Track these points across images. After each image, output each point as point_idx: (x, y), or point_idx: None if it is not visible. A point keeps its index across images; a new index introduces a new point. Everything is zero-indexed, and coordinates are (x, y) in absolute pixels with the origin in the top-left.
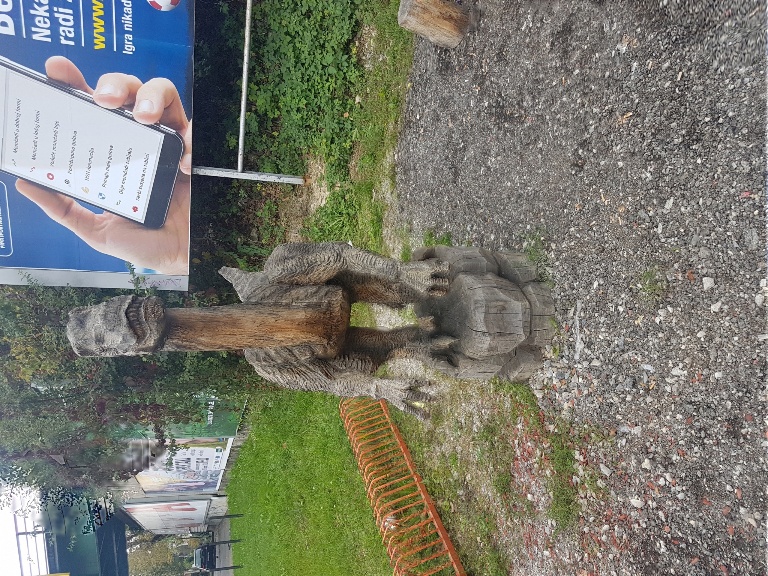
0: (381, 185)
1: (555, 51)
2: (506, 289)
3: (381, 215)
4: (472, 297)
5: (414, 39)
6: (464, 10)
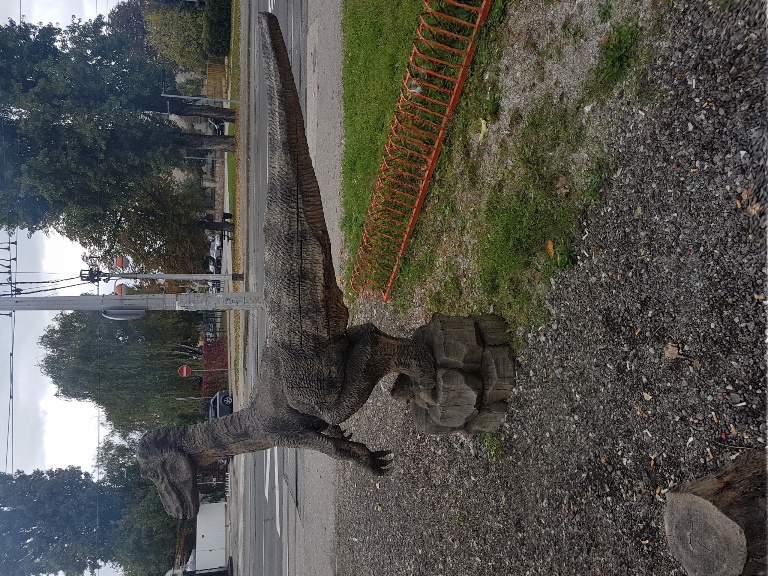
0: None
1: None
2: None
3: None
4: None
5: None
6: None
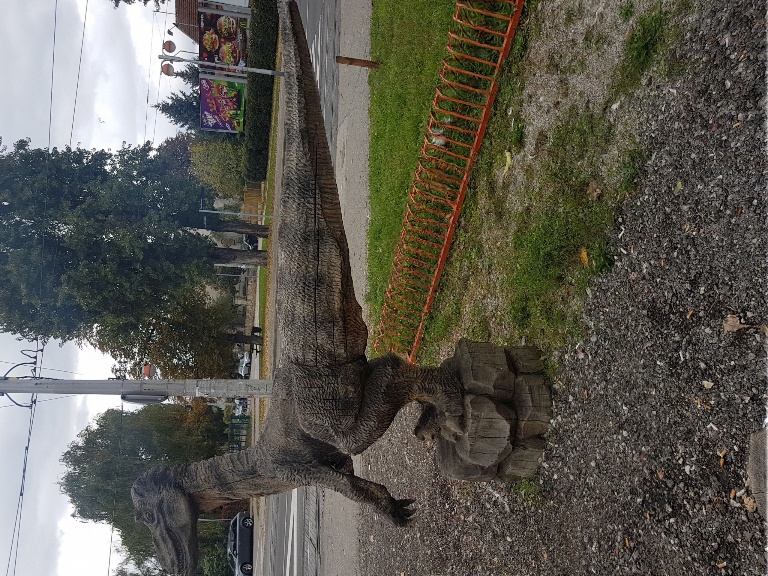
0: None
1: None
2: None
3: None
4: None
5: None
6: None
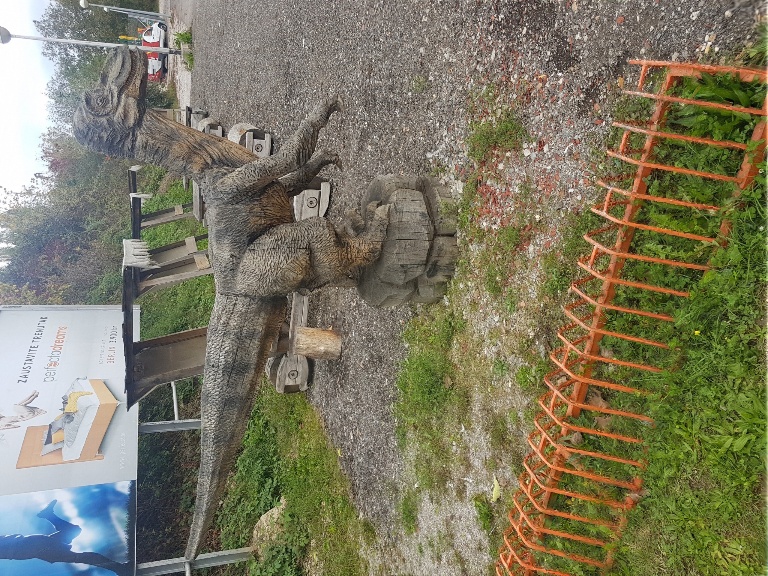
0: None
1: None
2: None
3: None
4: None
5: None
6: None
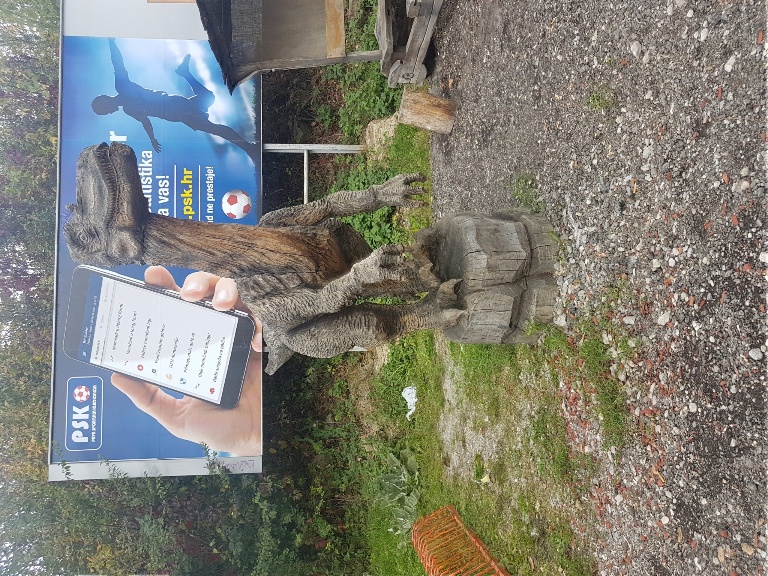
0: None
1: (504, 46)
2: (498, 219)
3: (432, 333)
4: (462, 226)
5: (431, 167)
6: (451, 99)
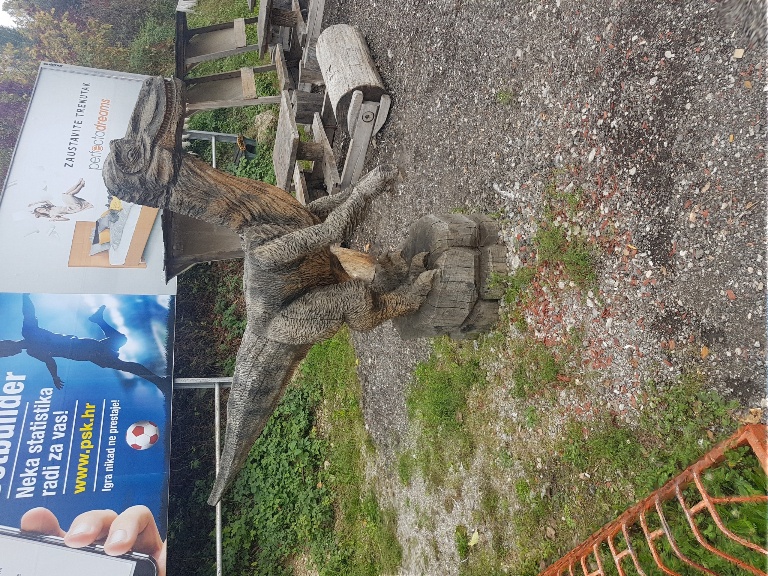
0: (365, 477)
1: (417, 165)
2: None
3: (373, 494)
4: None
5: (351, 344)
6: None
